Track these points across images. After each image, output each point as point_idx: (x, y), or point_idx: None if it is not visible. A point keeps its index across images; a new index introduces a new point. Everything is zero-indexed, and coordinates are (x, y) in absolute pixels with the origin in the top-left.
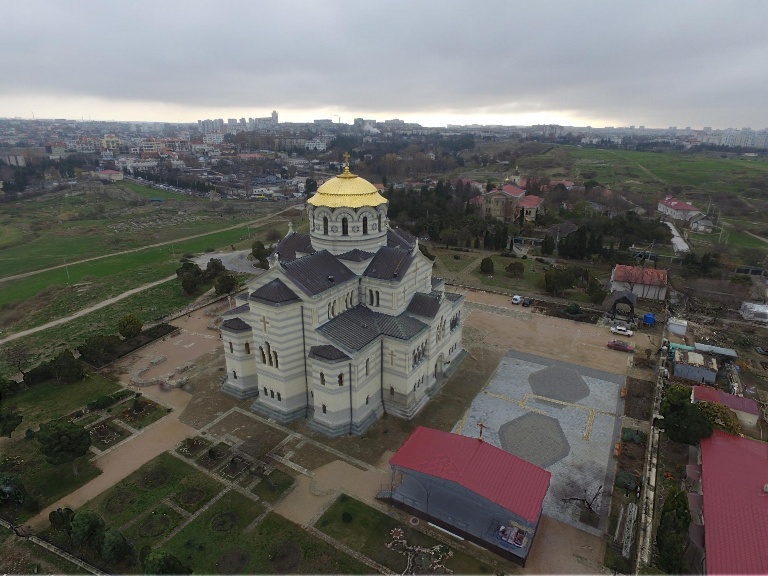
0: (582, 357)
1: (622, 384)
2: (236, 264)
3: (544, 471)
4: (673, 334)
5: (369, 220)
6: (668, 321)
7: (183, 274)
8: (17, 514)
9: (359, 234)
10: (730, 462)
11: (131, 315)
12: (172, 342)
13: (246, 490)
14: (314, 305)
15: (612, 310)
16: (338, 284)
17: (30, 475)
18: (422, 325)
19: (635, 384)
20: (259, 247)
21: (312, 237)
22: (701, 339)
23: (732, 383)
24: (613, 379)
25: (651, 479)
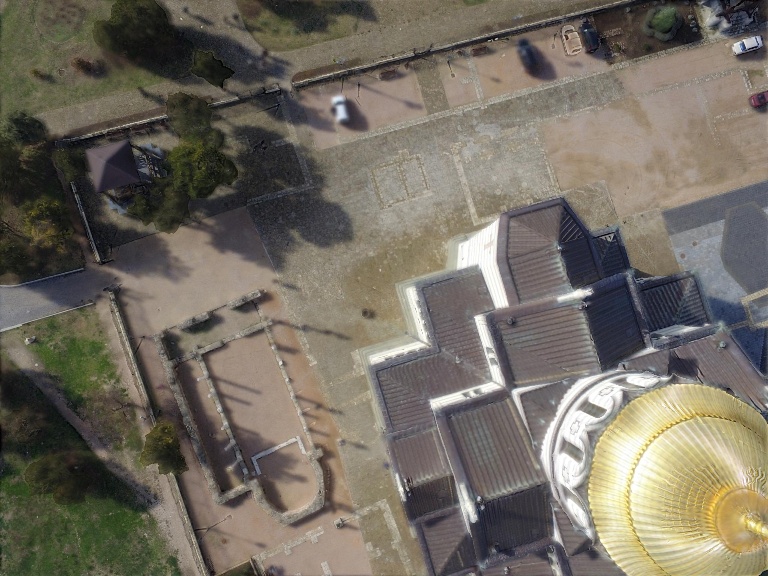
0: (739, 160)
1: None
2: None
3: None
4: None
5: None
6: None
7: None
8: None
9: None
10: None
11: None
12: None
13: None
14: None
15: None
16: None
17: None
18: None
19: None
20: None
21: None
22: None
23: None
24: None
25: None
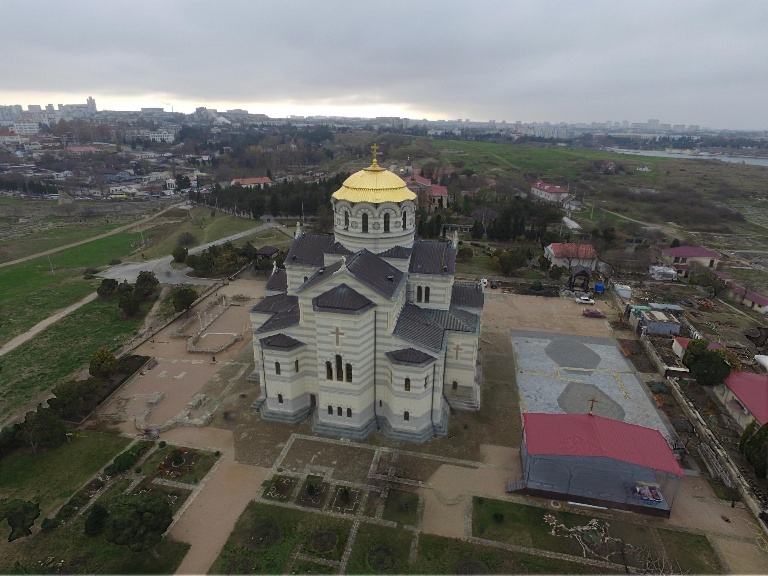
0: (571, 327)
1: (617, 346)
2: (163, 275)
3: (654, 430)
4: (623, 298)
5: (408, 214)
6: (616, 288)
7: (105, 293)
8: None
9: (400, 230)
10: (759, 393)
11: (104, 350)
12: (155, 375)
13: (377, 519)
14: (392, 308)
15: (568, 283)
16: (399, 283)
17: (90, 575)
18: (474, 316)
19: (627, 344)
20: (182, 254)
21: (345, 236)
22: (642, 300)
23: (692, 332)
24: (608, 343)
25: (700, 420)
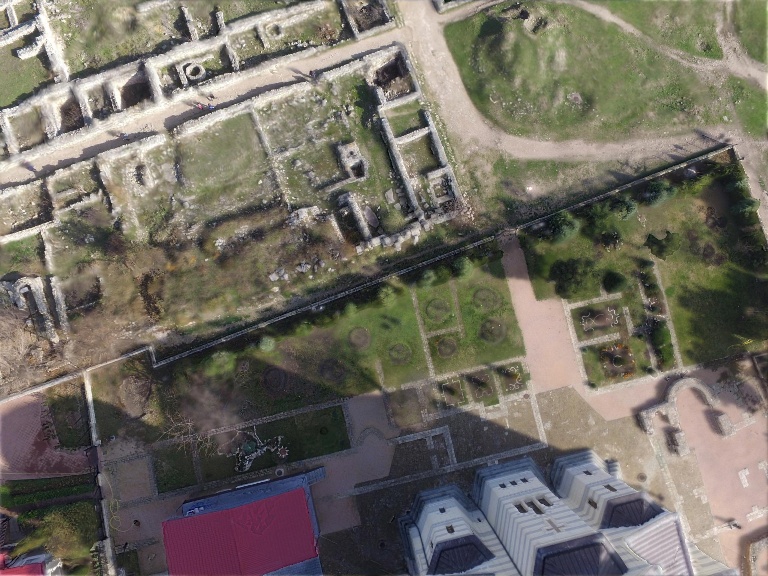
0: None
1: None
2: None
3: None
4: None
5: None
6: None
7: None
8: (532, 235)
9: None
10: None
11: None
12: None
13: (419, 386)
14: None
15: None
16: None
17: (580, 252)
18: None
19: None
20: None
21: None
22: None
23: None
24: None
25: None
